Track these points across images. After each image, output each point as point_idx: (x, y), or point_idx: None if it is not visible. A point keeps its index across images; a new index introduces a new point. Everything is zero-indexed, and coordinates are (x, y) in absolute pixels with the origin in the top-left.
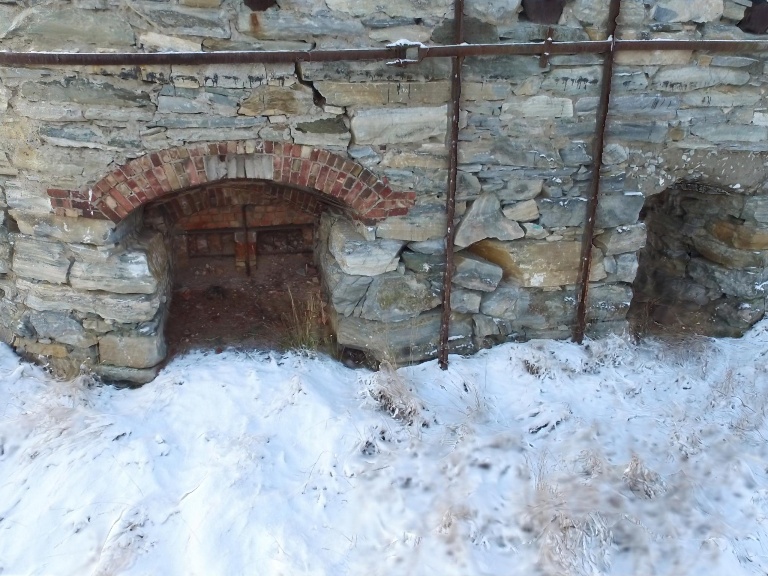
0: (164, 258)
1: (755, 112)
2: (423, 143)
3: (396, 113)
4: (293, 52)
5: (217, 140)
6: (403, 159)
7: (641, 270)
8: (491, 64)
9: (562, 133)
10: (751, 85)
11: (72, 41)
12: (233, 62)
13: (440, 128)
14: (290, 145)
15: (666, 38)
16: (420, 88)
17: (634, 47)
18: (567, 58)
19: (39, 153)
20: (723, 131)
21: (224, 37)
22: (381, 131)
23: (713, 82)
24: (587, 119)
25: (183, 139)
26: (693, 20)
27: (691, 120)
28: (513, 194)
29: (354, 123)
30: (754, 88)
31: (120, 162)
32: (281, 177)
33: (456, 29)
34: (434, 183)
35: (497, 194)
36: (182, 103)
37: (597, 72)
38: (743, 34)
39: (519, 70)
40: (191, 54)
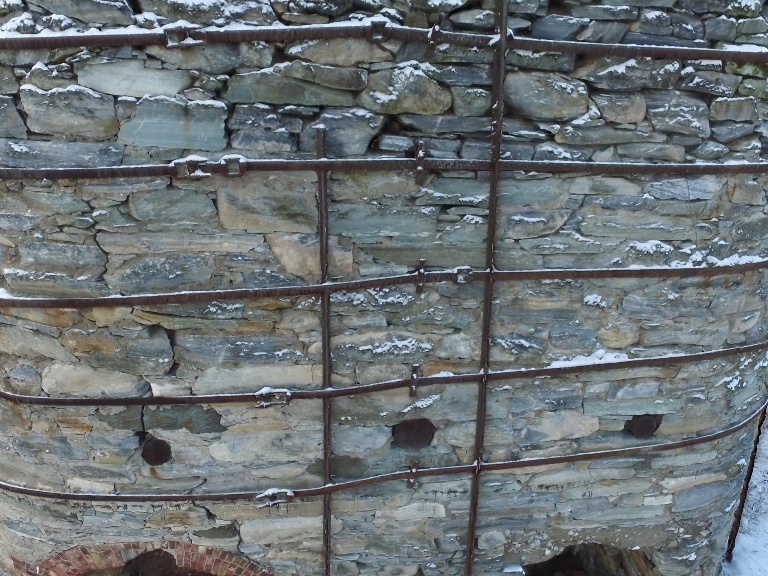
0: (115, 570)
1: (646, 497)
2: (304, 540)
3: (278, 522)
4: (182, 496)
5: (130, 542)
6: (285, 554)
7: (586, 548)
8: (361, 487)
9: (435, 530)
10: (639, 477)
11: (23, 473)
12: (136, 501)
13: (317, 532)
14: (189, 544)
15: (535, 456)
16: (297, 507)
17: (501, 467)
18: (435, 477)
19: (5, 533)
20: (611, 513)
21: (130, 483)
22: (266, 534)
23: (594, 480)
24: (461, 517)
25: (103, 542)
26: (566, 437)
27: (571, 511)
28: (389, 575)
29: (242, 530)
30: (643, 478)
31: (59, 551)
32: (183, 564)
33: (325, 469)
34: (314, 570)
35: (377, 572)
36: (101, 520)
37: (467, 485)
38: (624, 442)
39: (388, 489)
40: (104, 496)
